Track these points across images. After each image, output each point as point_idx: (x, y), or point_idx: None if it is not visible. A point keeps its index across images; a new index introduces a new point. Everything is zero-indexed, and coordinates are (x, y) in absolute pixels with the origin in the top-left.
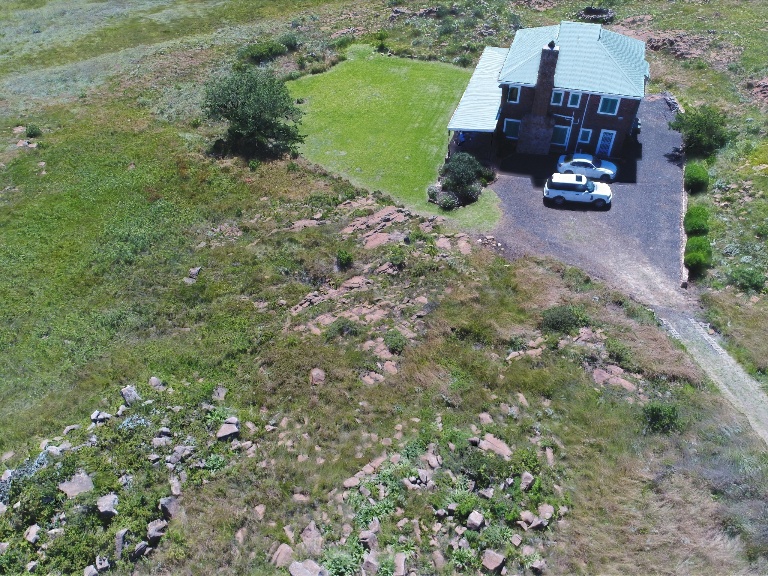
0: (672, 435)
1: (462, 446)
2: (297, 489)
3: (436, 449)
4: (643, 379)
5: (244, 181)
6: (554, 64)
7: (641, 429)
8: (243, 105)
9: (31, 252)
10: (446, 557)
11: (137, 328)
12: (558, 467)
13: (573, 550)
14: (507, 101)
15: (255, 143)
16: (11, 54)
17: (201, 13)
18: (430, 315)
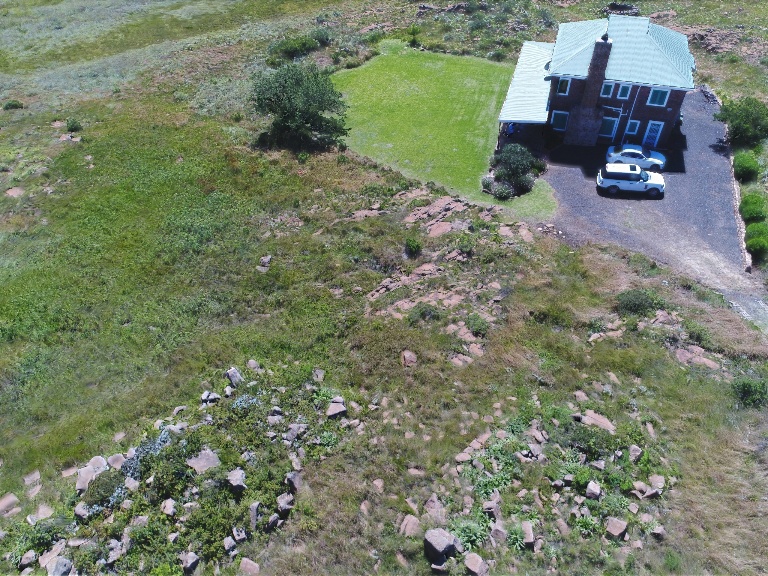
0: (763, 409)
1: (566, 421)
2: (411, 464)
3: (540, 425)
4: (724, 358)
5: (296, 173)
6: (607, 56)
7: (733, 404)
8: (289, 98)
9: (96, 243)
10: (569, 525)
11: (218, 314)
12: (661, 440)
13: (690, 516)
14: (556, 93)
15: (302, 136)
16: (35, 50)
17: (222, 9)
18: (506, 299)
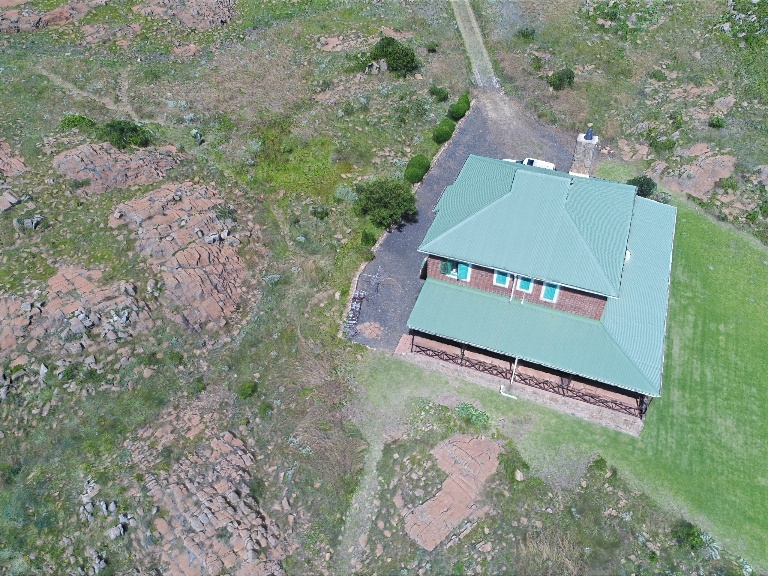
0: None
1: None
2: None
3: None
4: None
5: None
6: None
7: None
8: None
9: None
10: None
11: None
12: None
13: (575, 3)
14: None
15: None
16: None
17: None
18: None
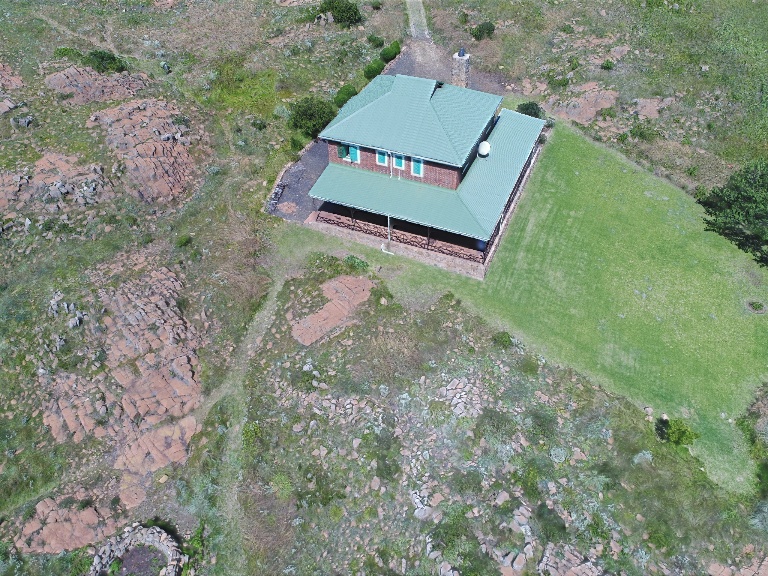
0: None
1: None
2: None
3: None
4: None
5: None
6: None
7: None
8: None
9: None
10: None
11: None
12: None
13: None
14: None
15: None
16: None
17: None
18: None
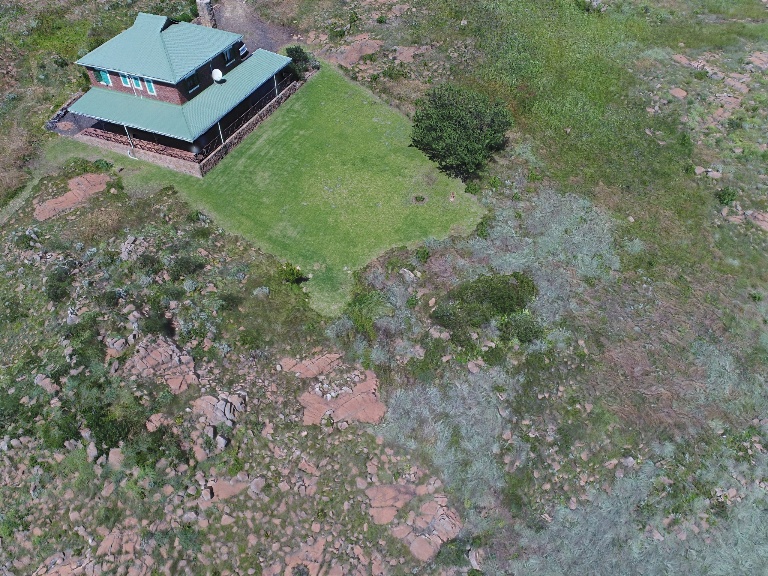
0: None
1: None
2: None
3: None
4: None
5: None
6: None
7: None
8: None
9: None
10: None
11: None
12: None
13: None
14: None
15: None
16: None
17: None
18: None
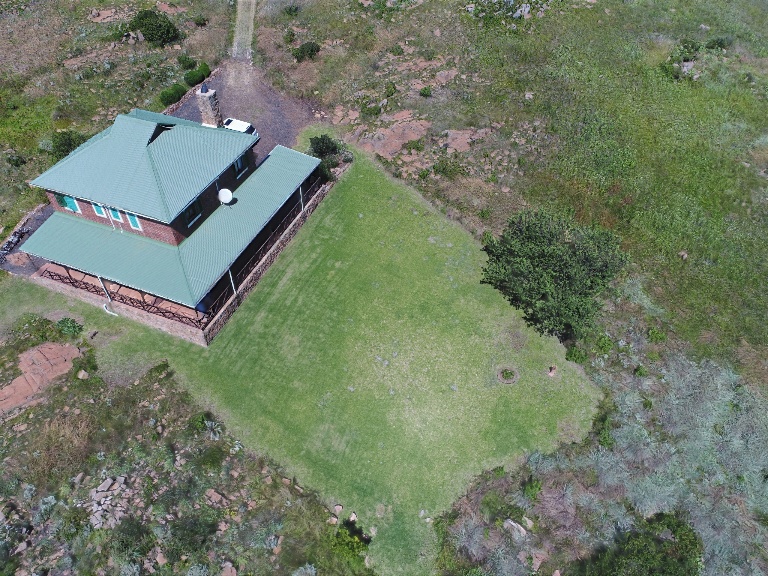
0: None
1: (377, 1)
2: None
3: (387, 5)
4: None
5: None
6: None
7: None
8: None
9: None
10: None
11: None
12: None
13: None
14: None
15: None
16: None
17: None
18: None
